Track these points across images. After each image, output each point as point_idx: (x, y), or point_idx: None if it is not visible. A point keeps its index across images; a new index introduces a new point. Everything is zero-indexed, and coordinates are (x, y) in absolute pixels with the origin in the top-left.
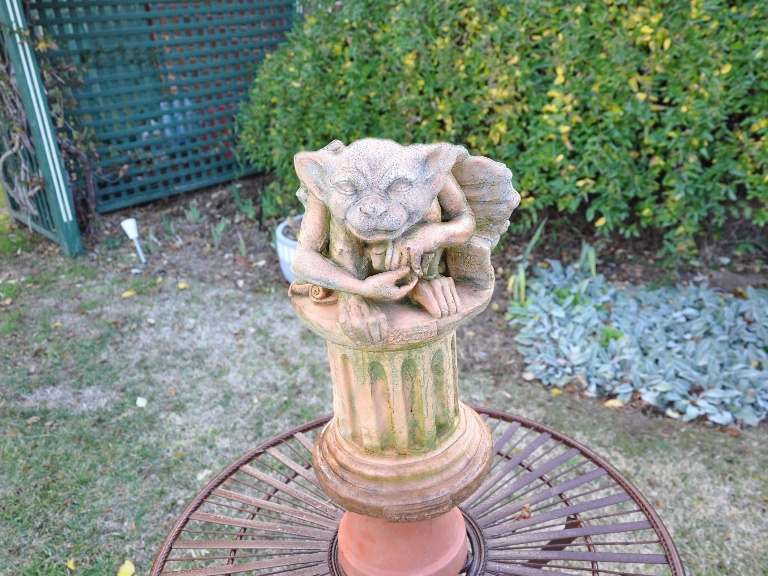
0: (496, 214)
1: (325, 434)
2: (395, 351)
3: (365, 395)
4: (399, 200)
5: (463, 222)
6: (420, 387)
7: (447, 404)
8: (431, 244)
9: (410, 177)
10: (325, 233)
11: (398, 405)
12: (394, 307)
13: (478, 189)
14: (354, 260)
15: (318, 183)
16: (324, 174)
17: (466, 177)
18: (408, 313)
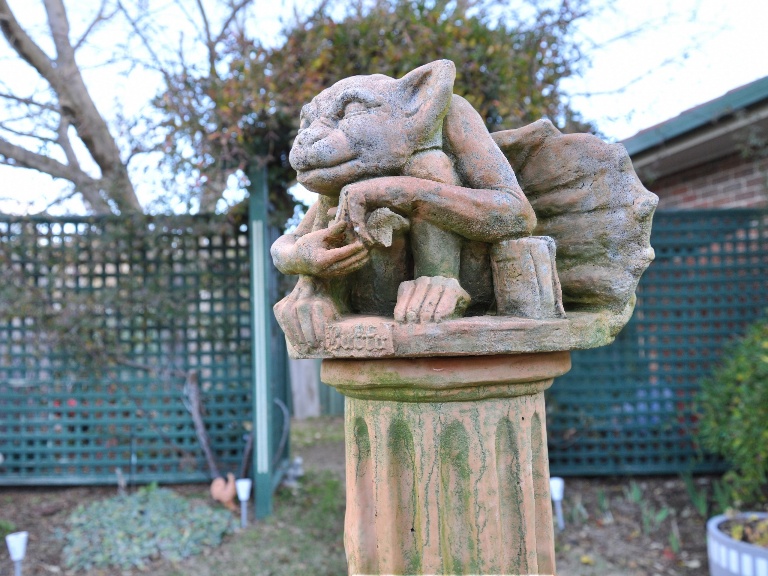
0: (610, 232)
1: None
2: (380, 399)
3: (351, 476)
4: (342, 126)
5: (475, 190)
6: (417, 479)
7: (477, 542)
8: (379, 189)
9: (363, 98)
10: None
11: (382, 502)
12: (370, 316)
13: (576, 190)
14: None
15: None
16: None
17: (553, 170)
18: (370, 317)
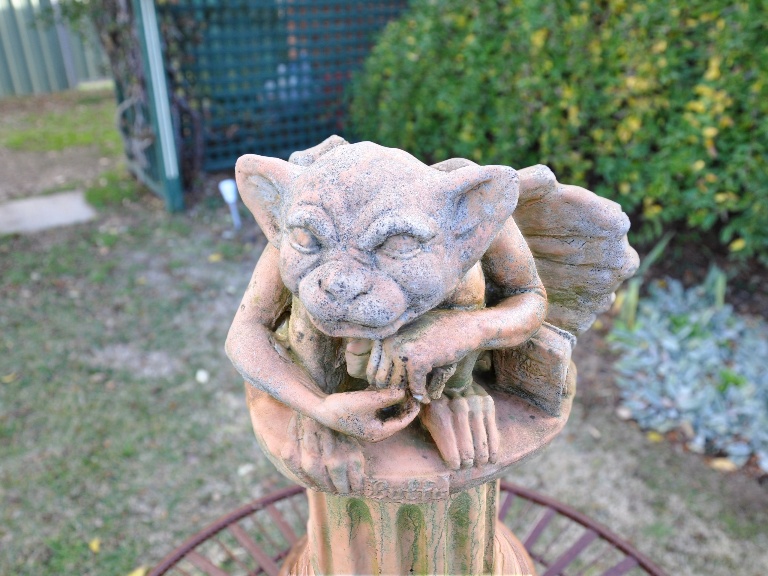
0: (589, 286)
1: (300, 552)
2: None
3: (340, 539)
4: (393, 274)
5: (520, 310)
6: (425, 544)
7: (470, 566)
8: (448, 355)
9: (419, 233)
10: (286, 297)
11: (388, 564)
12: None
13: (563, 244)
14: (321, 354)
15: (274, 217)
16: (281, 205)
17: (544, 223)
18: (405, 450)
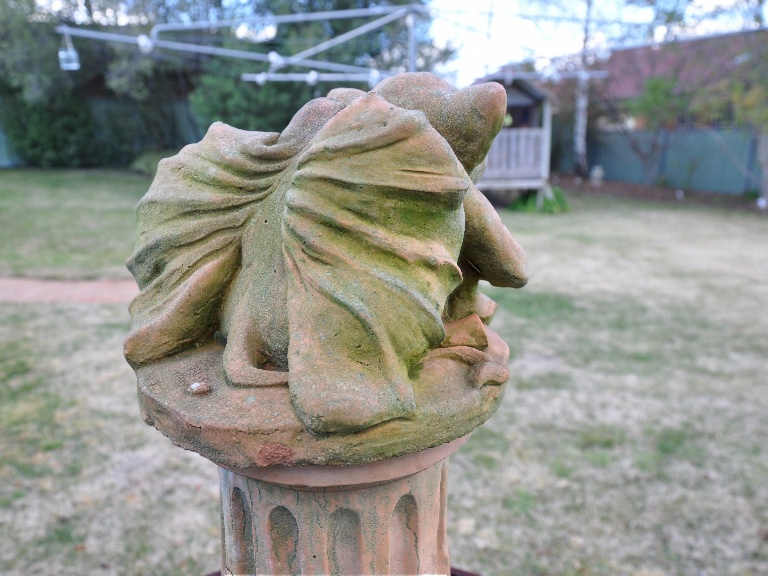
0: None
1: None
2: None
3: None
4: None
5: None
6: None
7: None
8: None
9: None
10: None
11: None
12: None
13: None
14: None
15: None
16: None
17: None
18: None
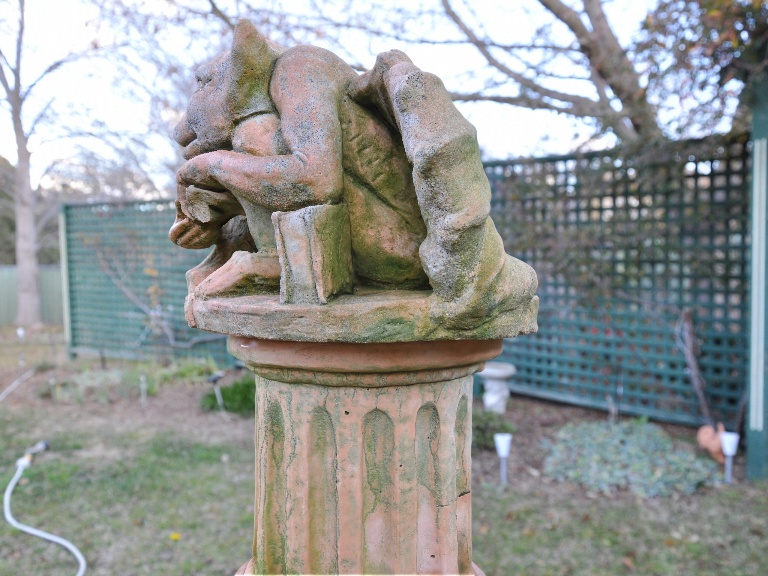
0: None
1: None
2: None
3: None
4: None
5: (258, 158)
6: None
7: None
8: None
9: None
10: None
11: None
12: None
13: None
14: None
15: None
16: None
17: None
18: None
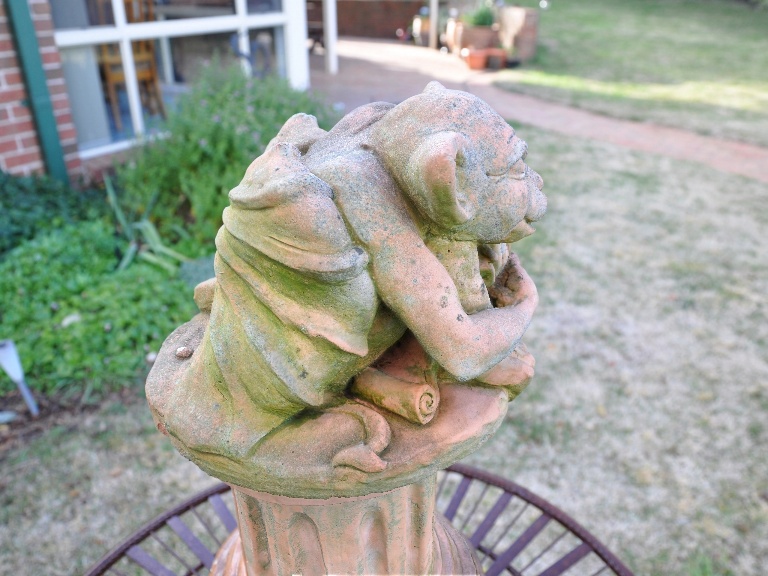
0: None
1: None
2: None
3: None
4: None
5: None
6: None
7: None
8: None
9: None
10: None
11: None
12: None
13: None
14: None
15: None
16: (469, 171)
17: None
18: None
